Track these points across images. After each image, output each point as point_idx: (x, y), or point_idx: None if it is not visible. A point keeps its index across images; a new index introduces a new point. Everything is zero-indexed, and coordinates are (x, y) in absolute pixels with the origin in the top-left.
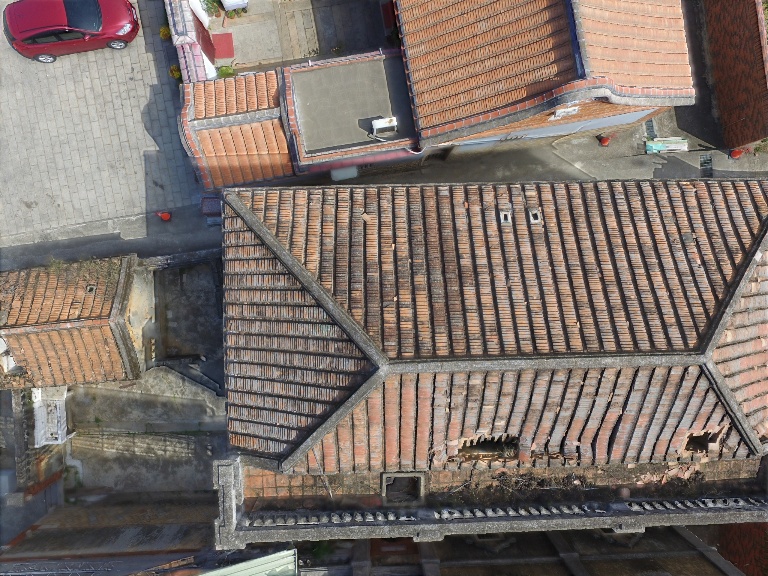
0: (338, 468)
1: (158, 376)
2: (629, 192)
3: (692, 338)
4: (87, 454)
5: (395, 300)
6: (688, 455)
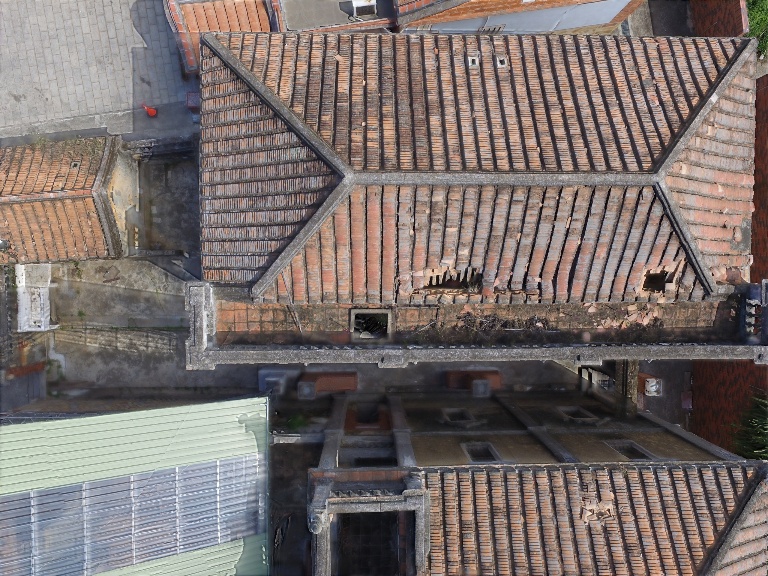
0: (307, 298)
1: (141, 271)
2: (594, 44)
3: (647, 162)
4: (70, 348)
5: (363, 125)
6: (646, 295)
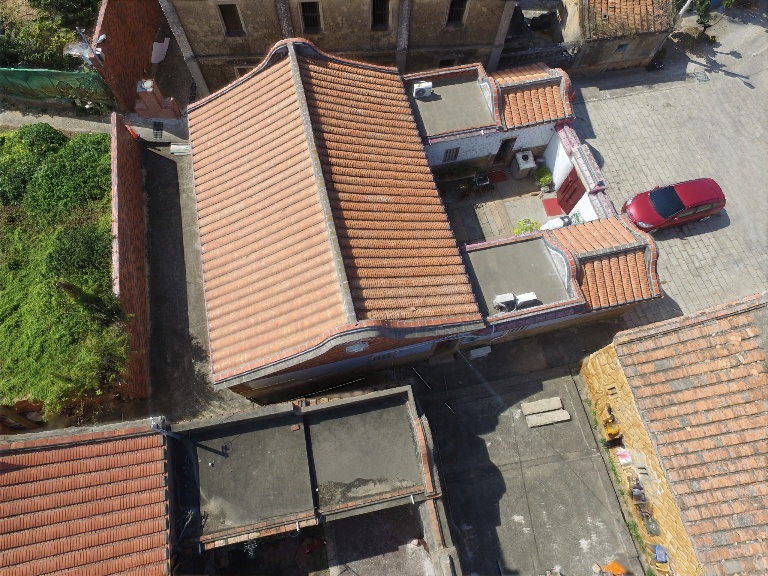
0: None
1: None
2: None
3: None
4: None
5: None
6: None
